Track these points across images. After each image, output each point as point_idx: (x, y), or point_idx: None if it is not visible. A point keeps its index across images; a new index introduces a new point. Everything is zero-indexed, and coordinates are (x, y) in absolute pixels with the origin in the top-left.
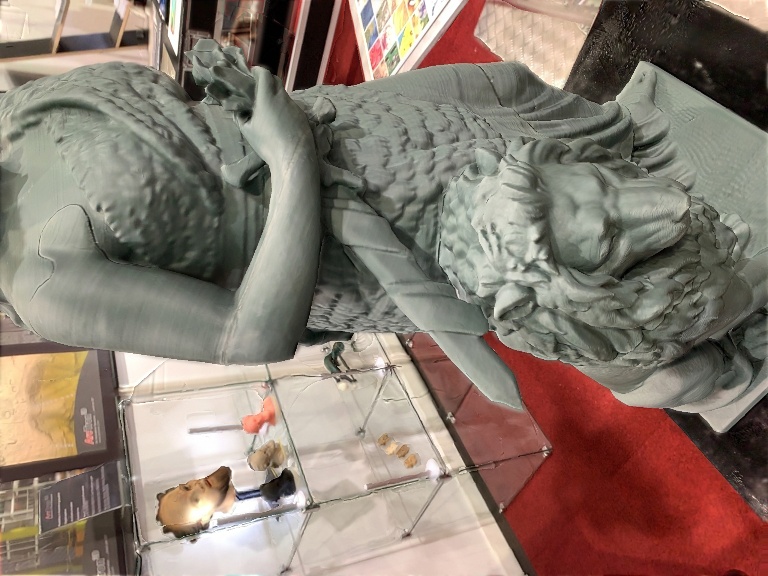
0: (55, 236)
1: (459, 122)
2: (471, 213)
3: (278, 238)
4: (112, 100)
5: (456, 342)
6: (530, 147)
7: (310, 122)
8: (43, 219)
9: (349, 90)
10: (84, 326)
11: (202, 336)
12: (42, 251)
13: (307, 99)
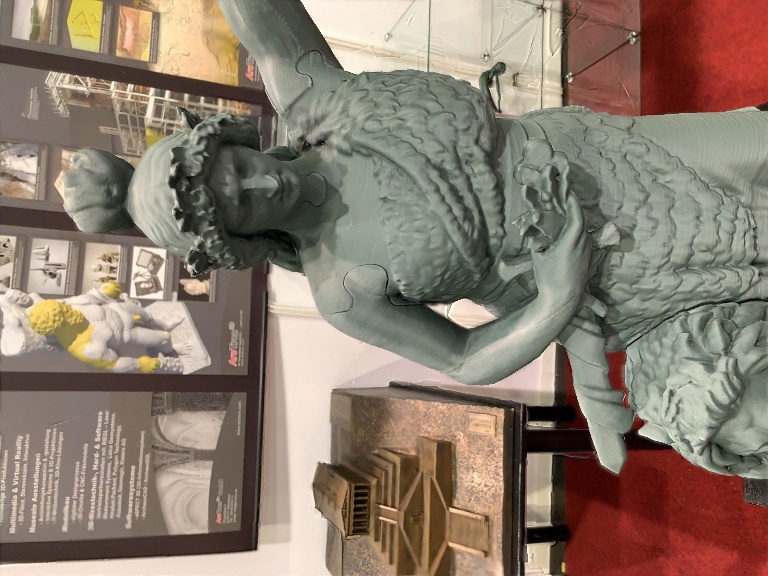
0: (359, 279)
1: (727, 241)
2: (673, 371)
3: (518, 346)
4: (438, 185)
5: (601, 431)
6: (756, 360)
7: (592, 248)
8: (354, 261)
9: (649, 156)
10: (359, 338)
11: (432, 365)
12: (346, 283)
13: (603, 174)
